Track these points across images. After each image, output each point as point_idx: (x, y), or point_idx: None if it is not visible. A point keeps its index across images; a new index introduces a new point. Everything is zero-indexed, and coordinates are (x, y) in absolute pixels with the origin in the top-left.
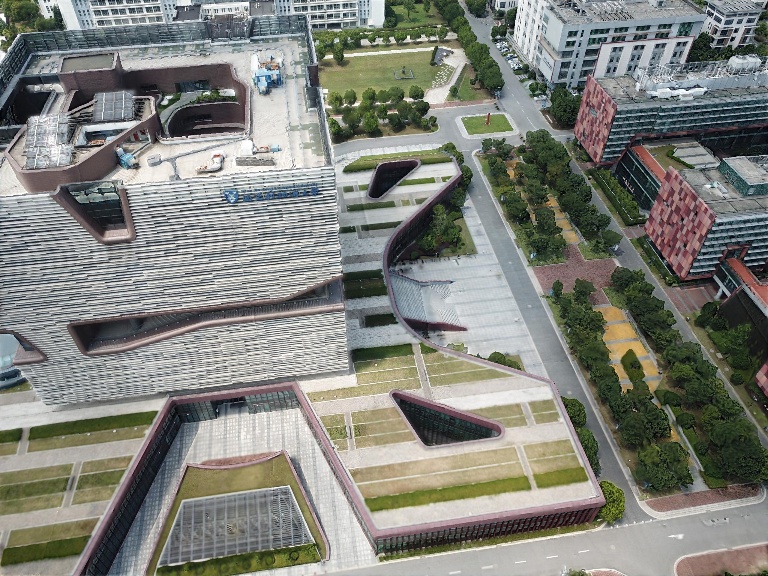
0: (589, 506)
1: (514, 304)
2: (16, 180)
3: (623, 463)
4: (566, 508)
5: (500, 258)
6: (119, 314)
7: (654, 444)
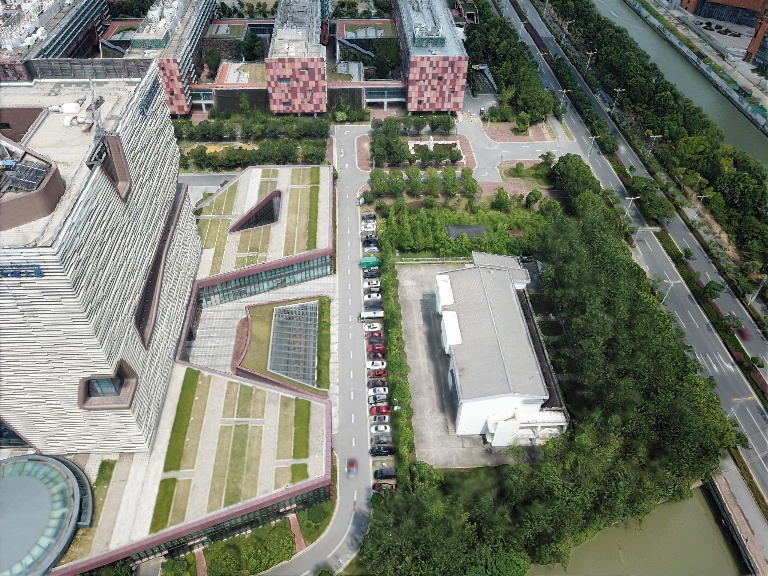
0: None
1: None
2: (7, 231)
3: None
4: None
5: None
6: (144, 280)
7: (301, 148)
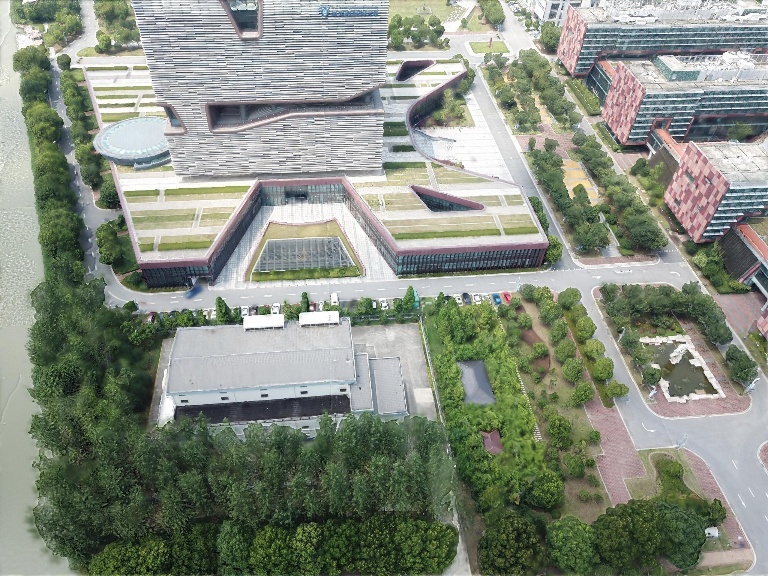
0: (538, 245)
1: (500, 156)
2: None
3: (566, 241)
4: (523, 245)
5: (492, 130)
6: (240, 99)
7: None
